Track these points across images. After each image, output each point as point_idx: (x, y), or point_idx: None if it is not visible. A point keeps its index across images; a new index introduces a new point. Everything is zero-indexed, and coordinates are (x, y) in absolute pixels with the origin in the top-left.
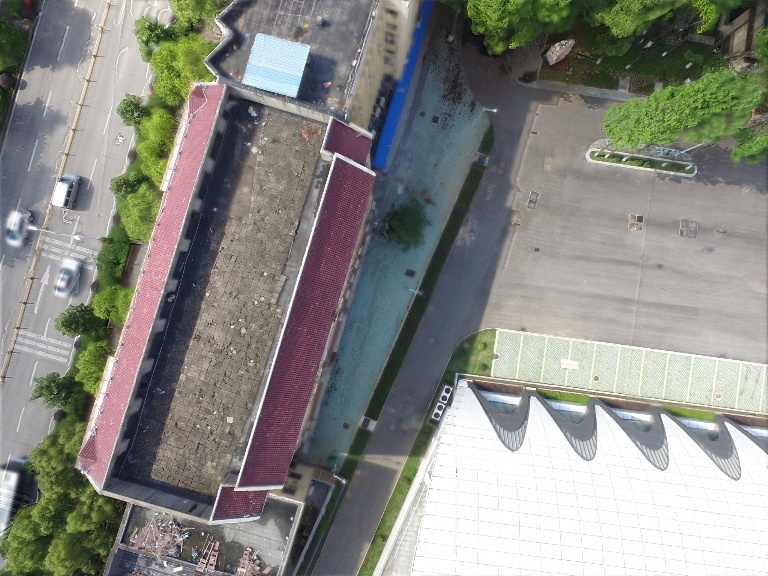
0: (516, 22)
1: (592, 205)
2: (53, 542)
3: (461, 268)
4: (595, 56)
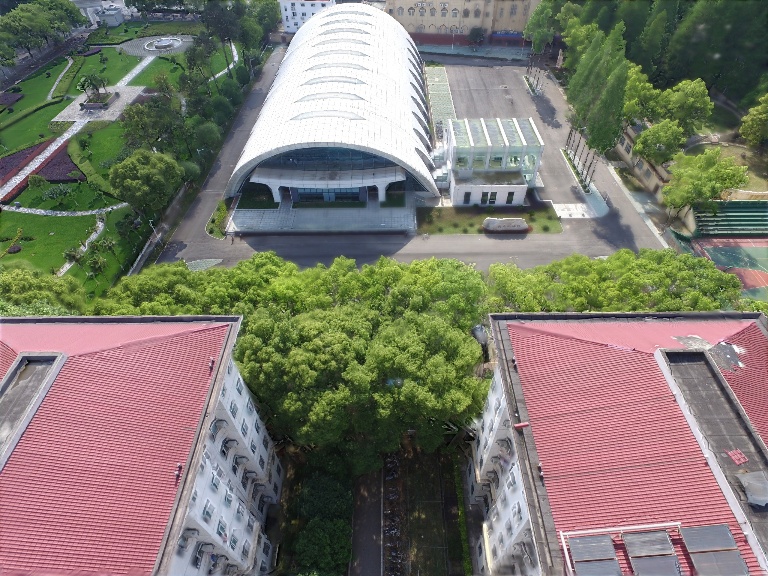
0: None
1: None
2: None
3: (465, 60)
4: None
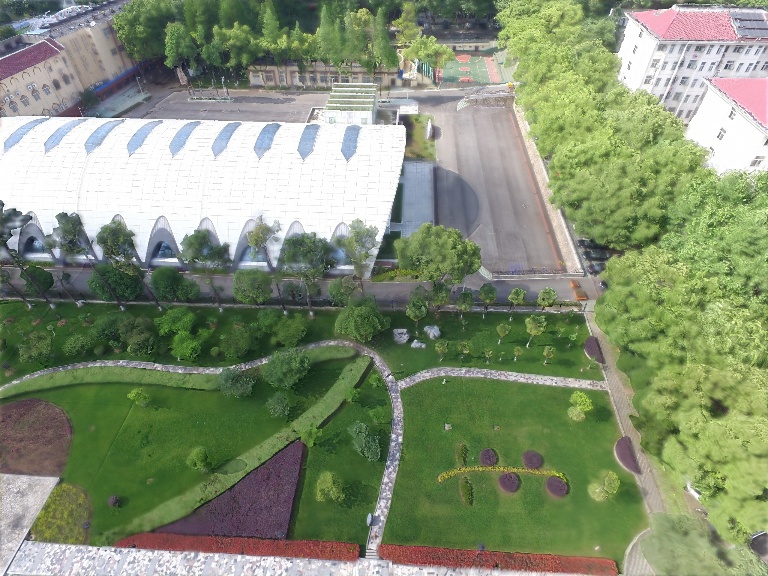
0: (130, 37)
1: None
2: None
3: None
4: None
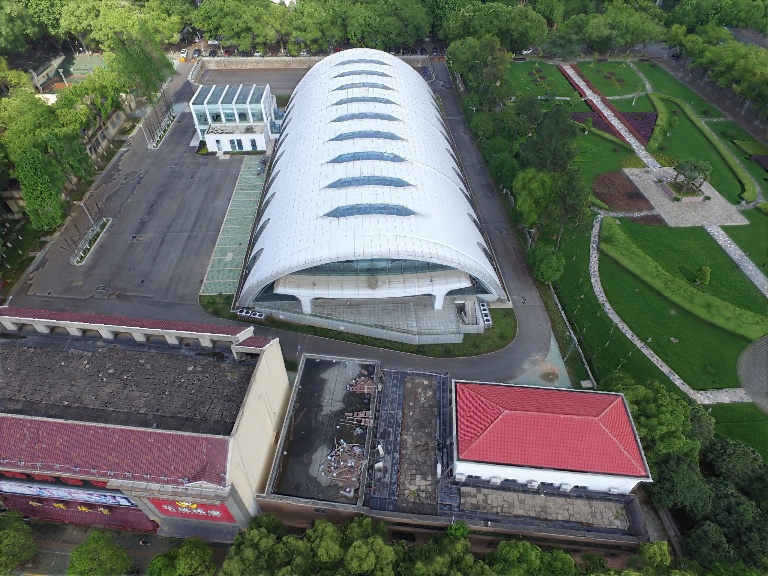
0: None
1: (117, 259)
2: (351, 569)
3: None
4: (4, 269)
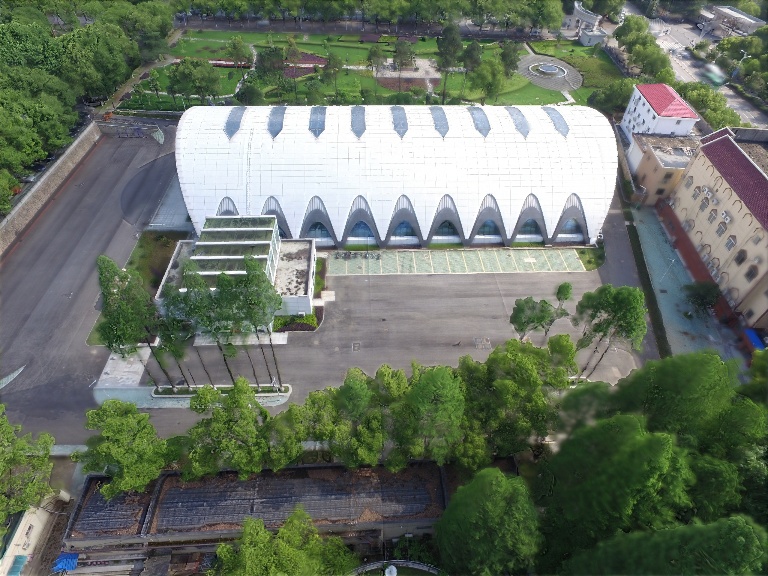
0: None
1: None
2: None
3: None
4: None
